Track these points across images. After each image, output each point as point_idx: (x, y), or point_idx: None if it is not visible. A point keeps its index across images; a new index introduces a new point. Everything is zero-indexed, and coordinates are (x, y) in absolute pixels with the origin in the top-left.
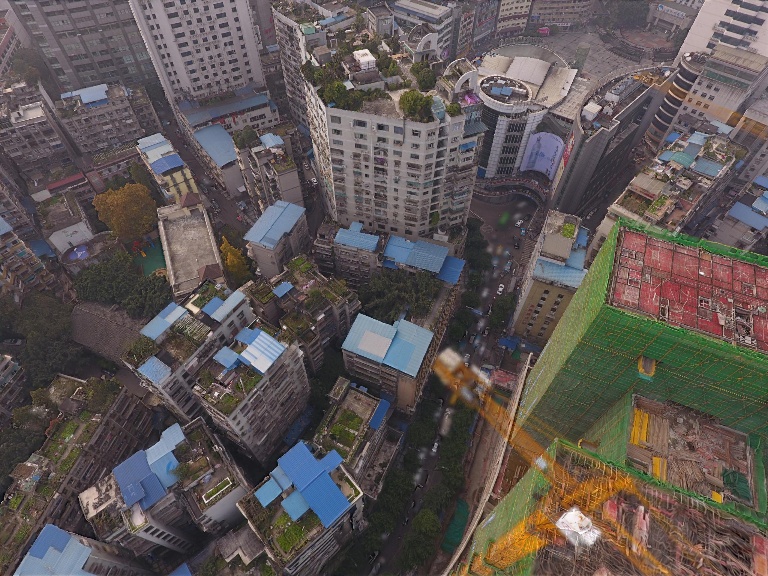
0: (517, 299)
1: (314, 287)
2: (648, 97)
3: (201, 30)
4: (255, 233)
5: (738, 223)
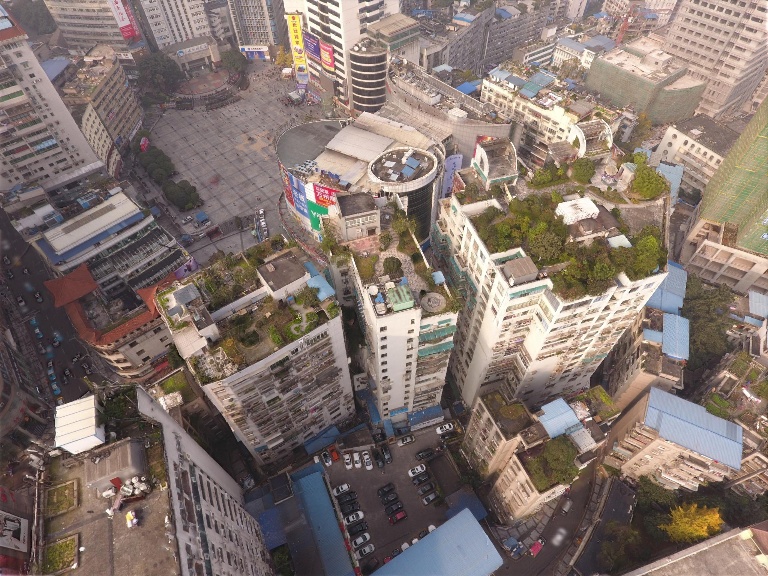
0: None
1: None
2: None
3: None
4: (725, 452)
5: None
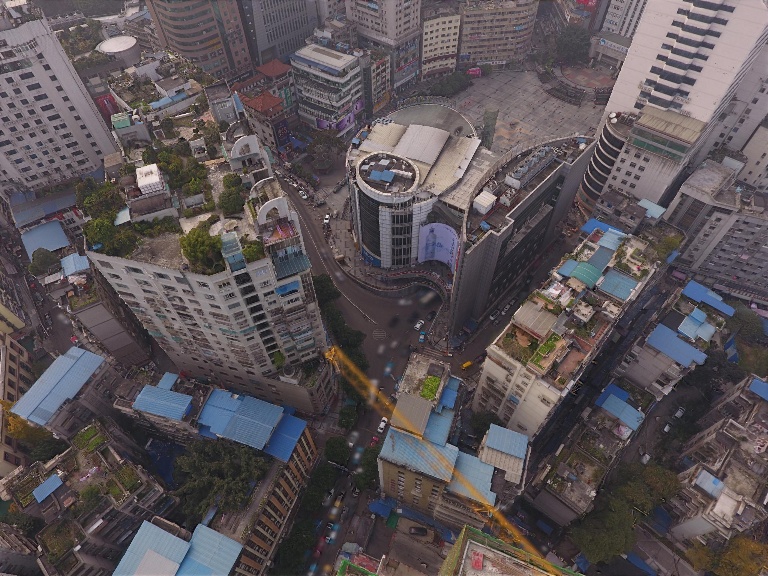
0: None
1: (98, 475)
2: (560, 176)
3: (17, 115)
4: (27, 402)
5: (660, 354)
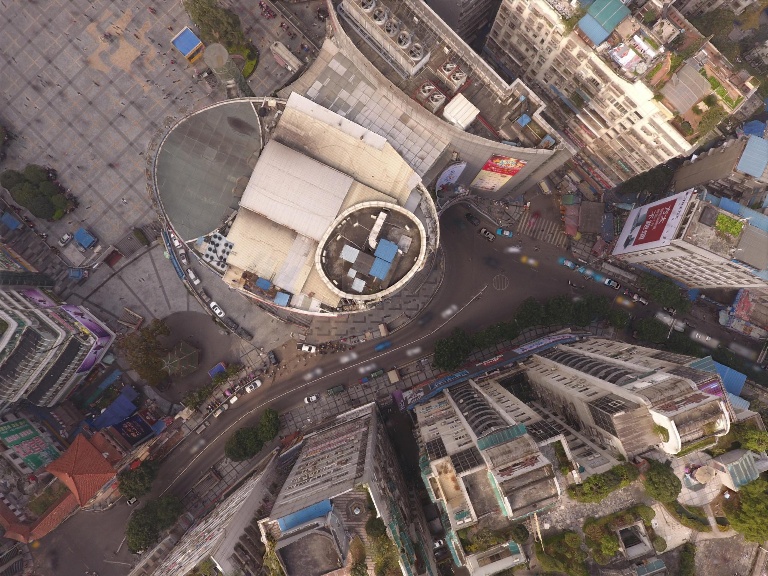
0: (649, 271)
1: None
2: None
3: None
4: None
5: None
